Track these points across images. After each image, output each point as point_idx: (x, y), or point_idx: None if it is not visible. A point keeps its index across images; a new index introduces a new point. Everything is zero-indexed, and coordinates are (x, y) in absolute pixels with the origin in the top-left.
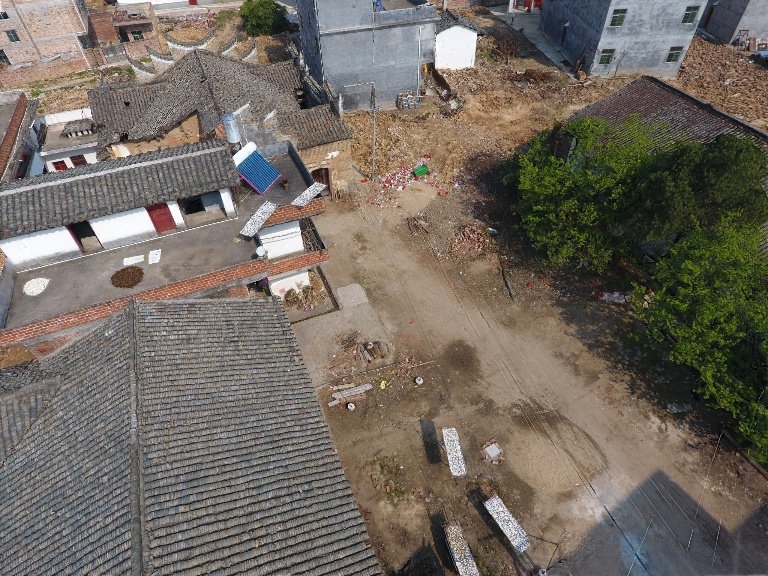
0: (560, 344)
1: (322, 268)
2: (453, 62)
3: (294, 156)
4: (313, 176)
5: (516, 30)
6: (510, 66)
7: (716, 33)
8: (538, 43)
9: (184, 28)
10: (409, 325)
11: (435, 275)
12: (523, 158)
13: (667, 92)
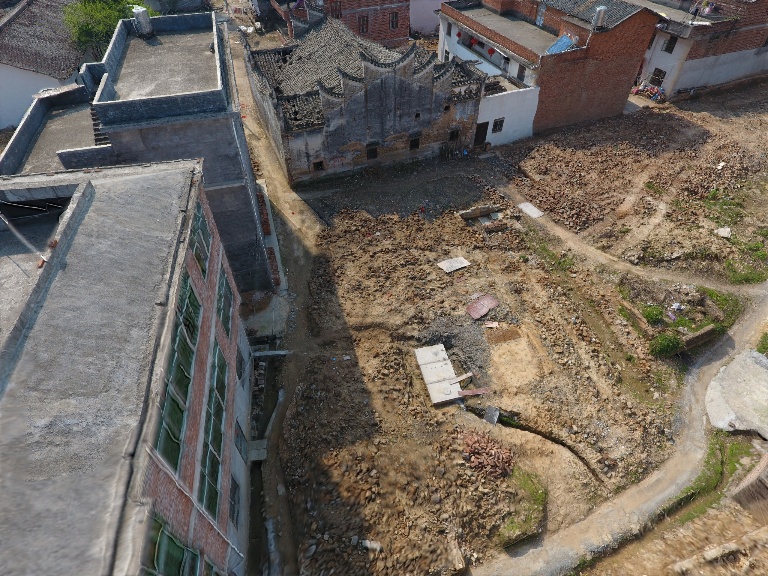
0: None
1: None
2: None
3: None
4: None
5: None
6: None
7: None
8: None
9: None
10: None
11: None
12: None
13: None
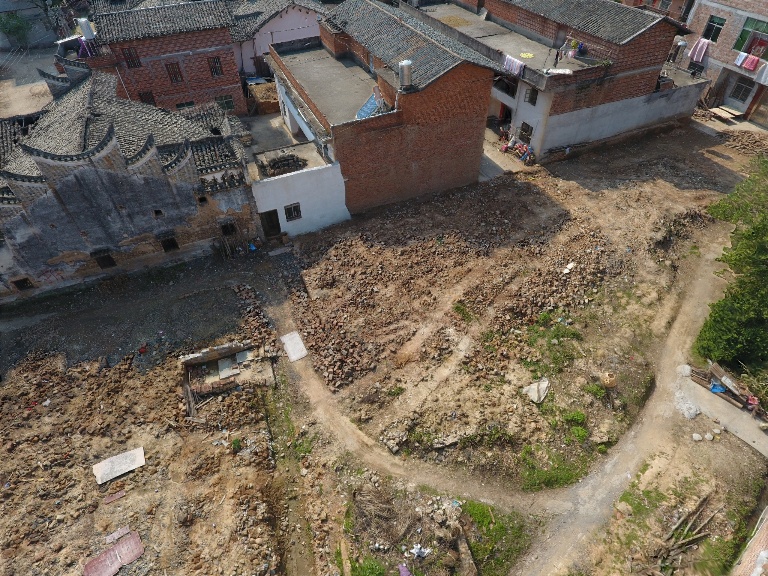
0: None
1: None
2: None
3: None
4: None
5: None
6: None
7: None
8: None
9: None
10: None
11: None
12: None
13: None
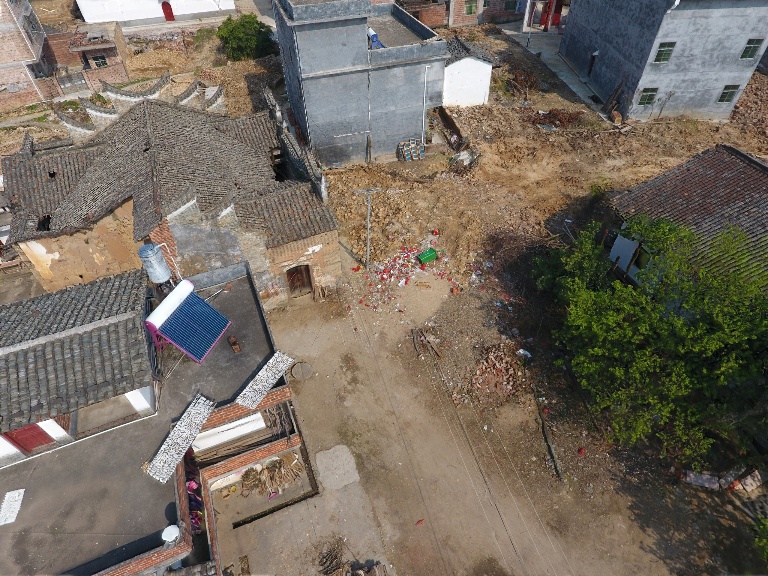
0: (636, 570)
1: (297, 415)
2: (463, 98)
3: (253, 286)
4: (289, 273)
5: (533, 54)
6: (530, 102)
7: (766, 61)
8: (560, 72)
9: (156, 50)
10: (416, 527)
11: (451, 431)
12: (567, 262)
13: (756, 171)
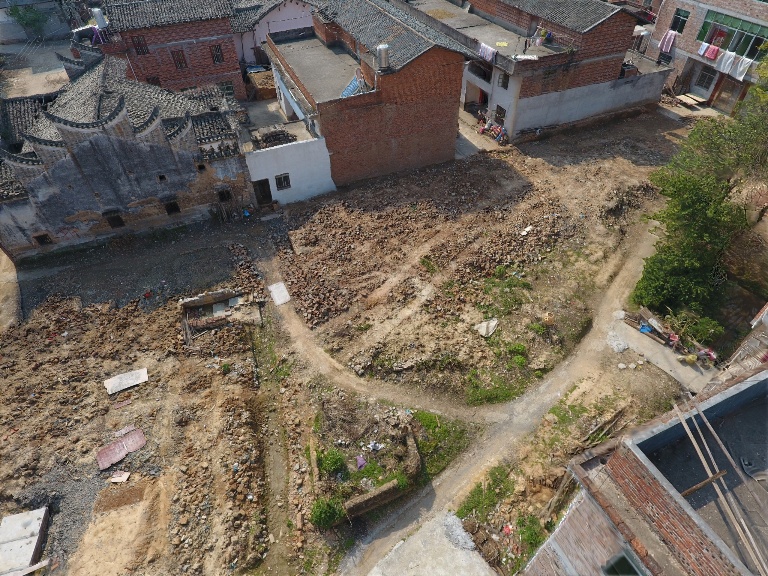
0: None
1: None
2: None
3: None
4: None
5: None
6: None
7: None
8: None
9: None
10: None
11: None
12: None
13: None
